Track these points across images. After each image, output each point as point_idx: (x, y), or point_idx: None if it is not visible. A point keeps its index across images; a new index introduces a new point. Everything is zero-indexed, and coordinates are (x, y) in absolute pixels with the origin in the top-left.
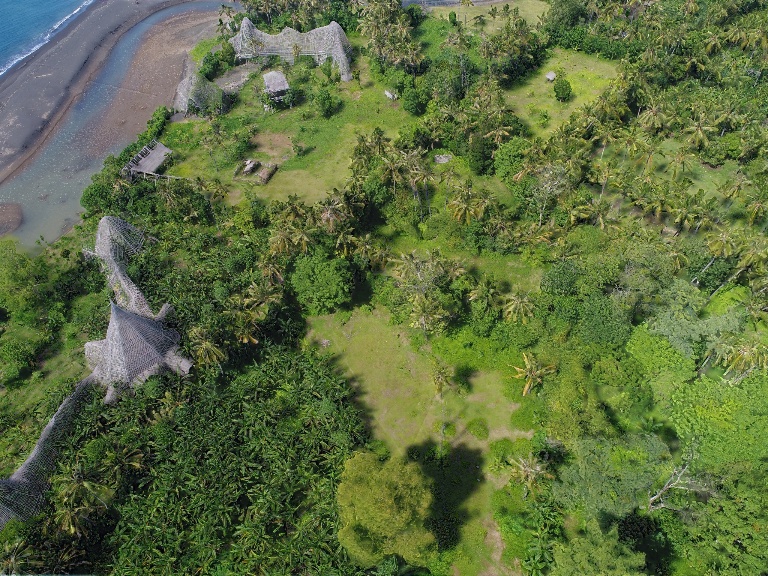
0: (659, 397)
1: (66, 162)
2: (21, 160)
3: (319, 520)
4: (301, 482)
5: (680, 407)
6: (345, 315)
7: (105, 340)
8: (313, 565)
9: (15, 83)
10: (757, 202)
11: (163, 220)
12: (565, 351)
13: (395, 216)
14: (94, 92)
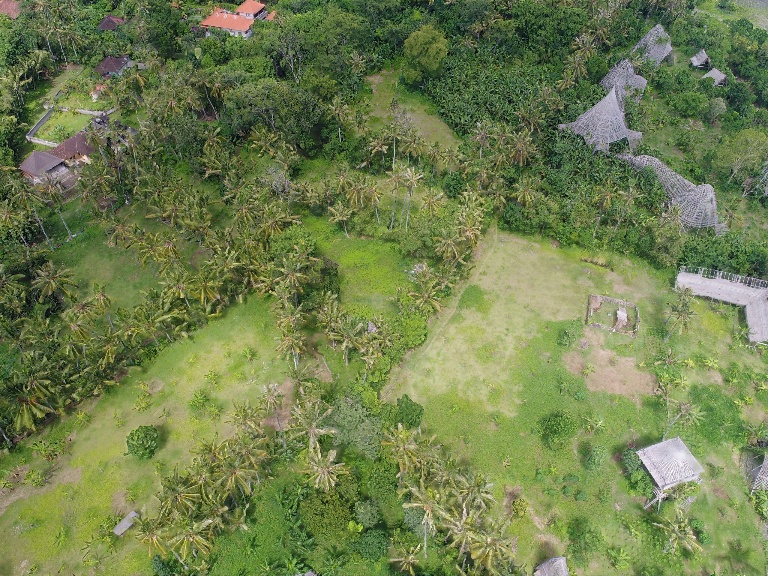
0: None
1: None
2: None
3: None
4: None
5: None
6: None
7: None
8: None
9: None
10: (105, 174)
11: None
12: None
13: None
14: None
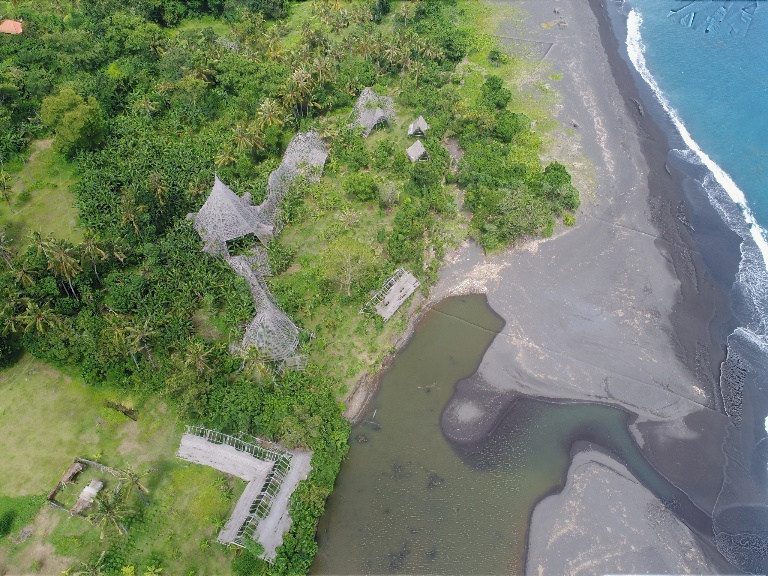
0: None
1: None
2: None
3: None
4: None
5: None
6: None
7: None
8: None
9: None
10: None
11: None
12: None
13: None
14: None
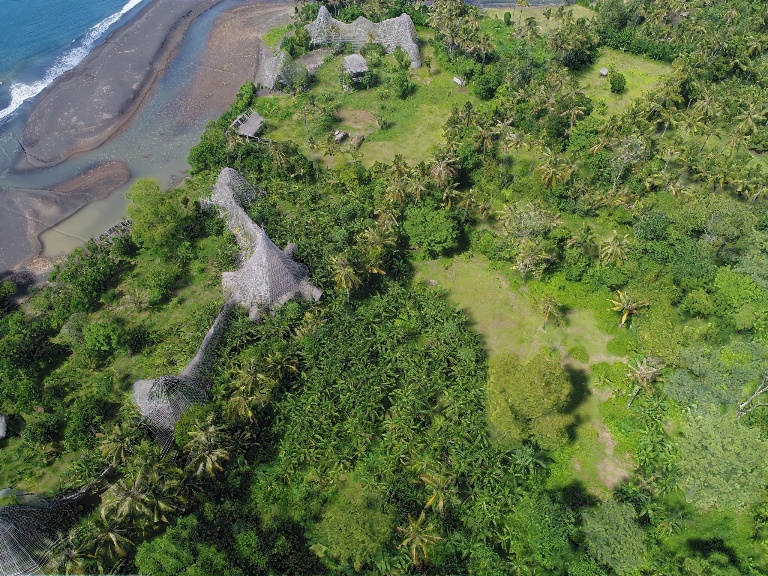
0: (741, 327)
1: (162, 127)
2: (119, 124)
3: (458, 416)
4: (436, 387)
5: (762, 333)
6: (447, 261)
7: (246, 268)
8: (456, 451)
9: (100, 57)
10: None
11: (267, 178)
12: (654, 290)
13: (482, 181)
14: (176, 68)
